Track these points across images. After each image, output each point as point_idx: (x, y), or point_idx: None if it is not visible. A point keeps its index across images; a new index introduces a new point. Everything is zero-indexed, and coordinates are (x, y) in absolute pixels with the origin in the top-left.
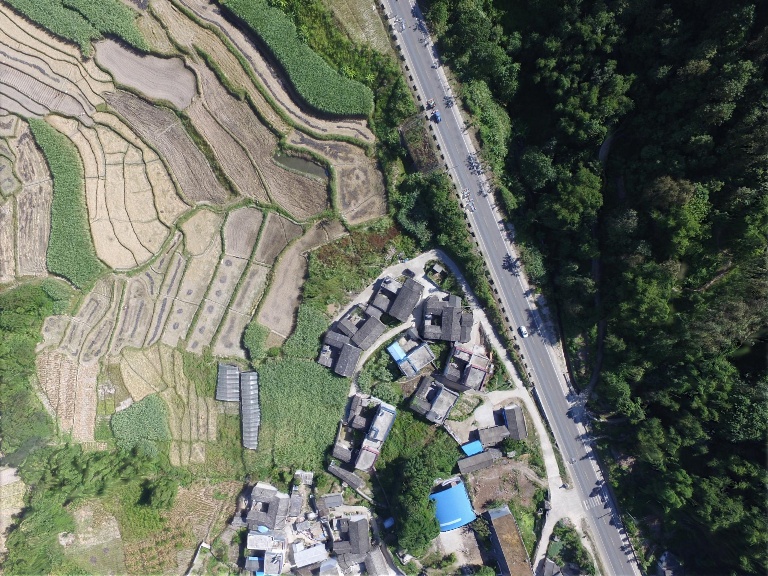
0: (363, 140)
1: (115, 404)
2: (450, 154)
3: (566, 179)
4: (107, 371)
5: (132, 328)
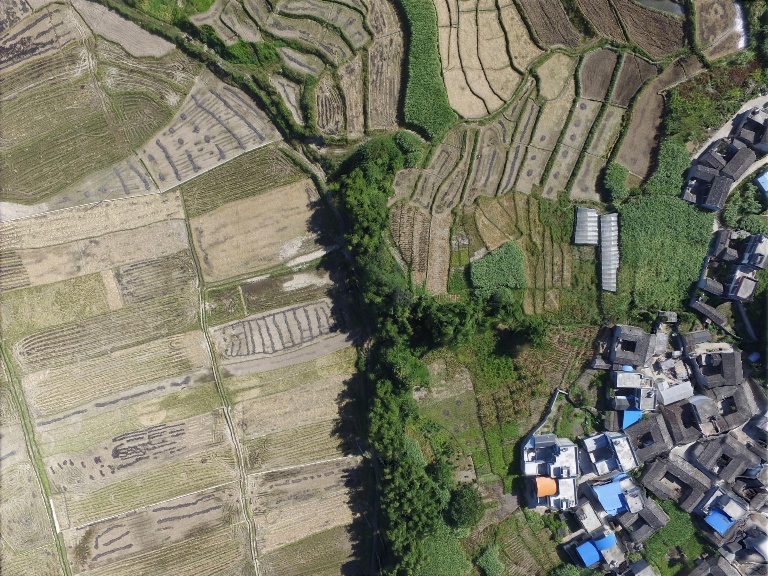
0: None
1: (469, 254)
2: None
3: None
4: (461, 222)
5: (485, 177)
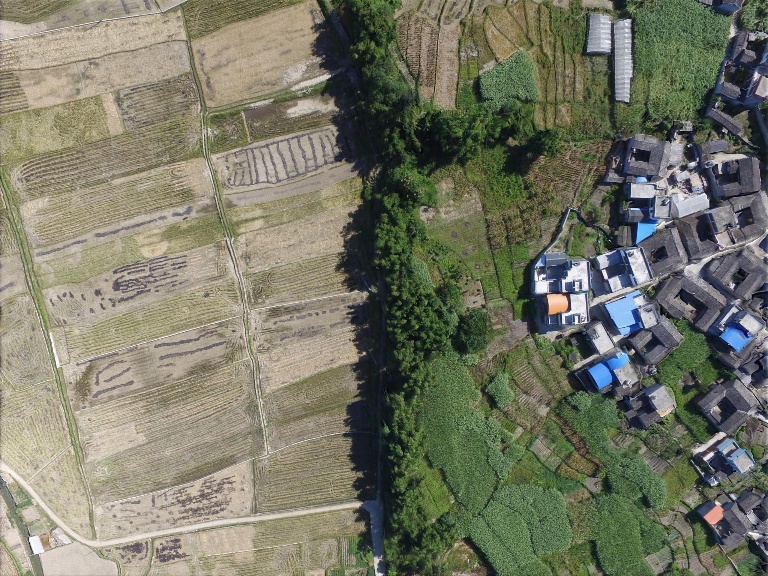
0: None
1: (478, 67)
2: None
3: None
4: (470, 32)
5: None
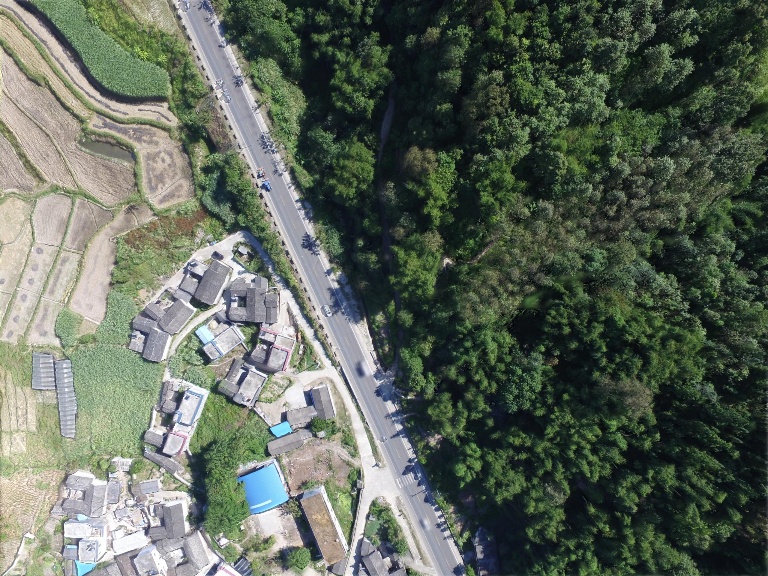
0: (165, 123)
1: None
2: (243, 134)
3: (342, 154)
4: None
5: None
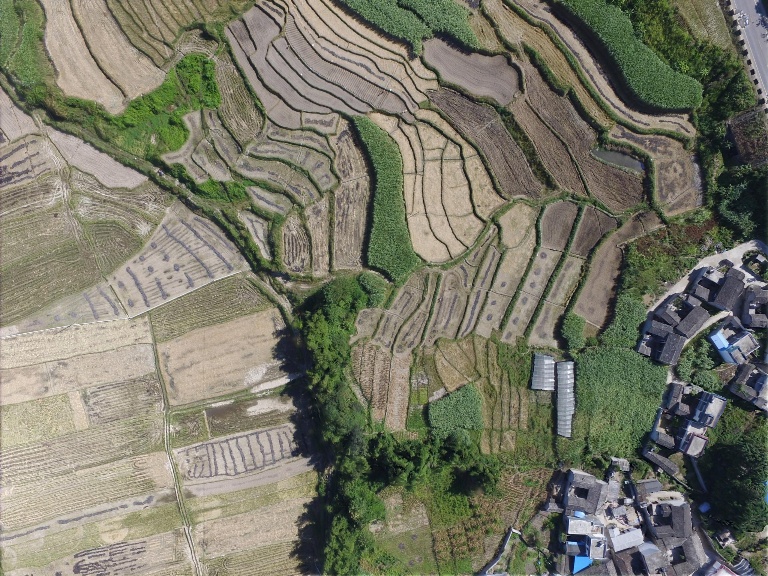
0: (684, 134)
1: (428, 394)
2: None
3: None
4: (421, 362)
5: (445, 320)
